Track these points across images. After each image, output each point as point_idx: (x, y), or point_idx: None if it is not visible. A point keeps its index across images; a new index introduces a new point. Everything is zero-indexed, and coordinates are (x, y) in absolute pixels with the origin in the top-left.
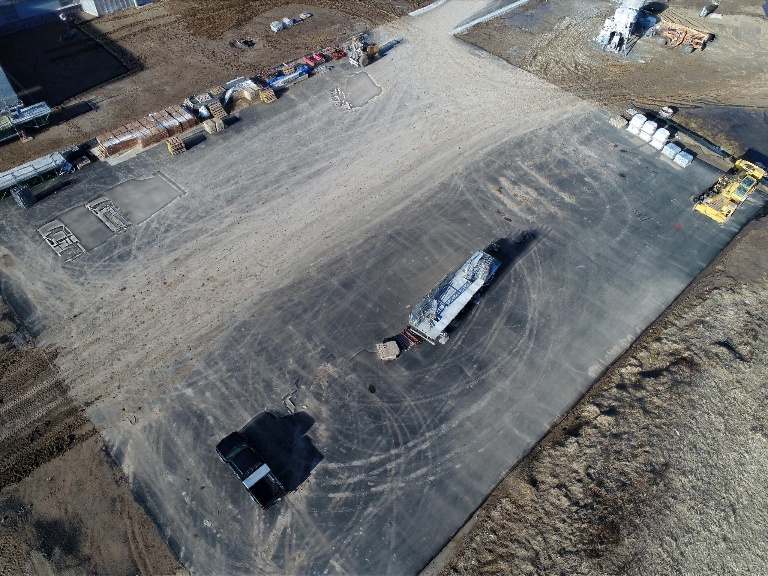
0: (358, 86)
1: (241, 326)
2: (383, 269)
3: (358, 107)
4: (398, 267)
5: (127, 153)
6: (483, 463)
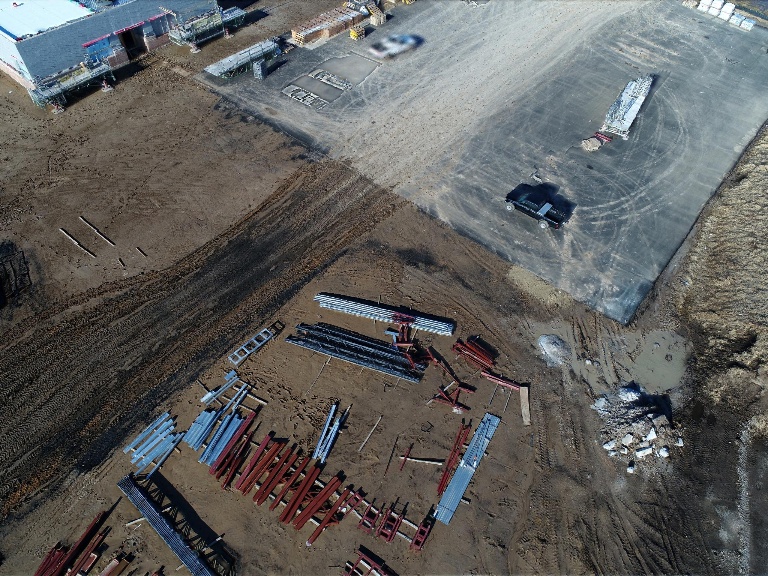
0: None
1: (476, 138)
2: (560, 101)
3: (483, 4)
4: (570, 99)
5: (318, 41)
6: (687, 201)
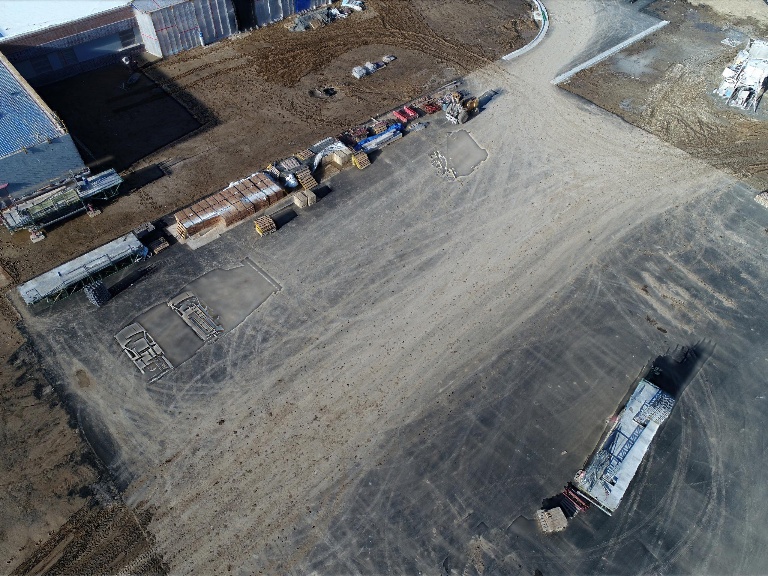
0: (460, 148)
1: (368, 479)
2: (526, 398)
3: (464, 176)
4: (543, 395)
5: (209, 233)
6: None
